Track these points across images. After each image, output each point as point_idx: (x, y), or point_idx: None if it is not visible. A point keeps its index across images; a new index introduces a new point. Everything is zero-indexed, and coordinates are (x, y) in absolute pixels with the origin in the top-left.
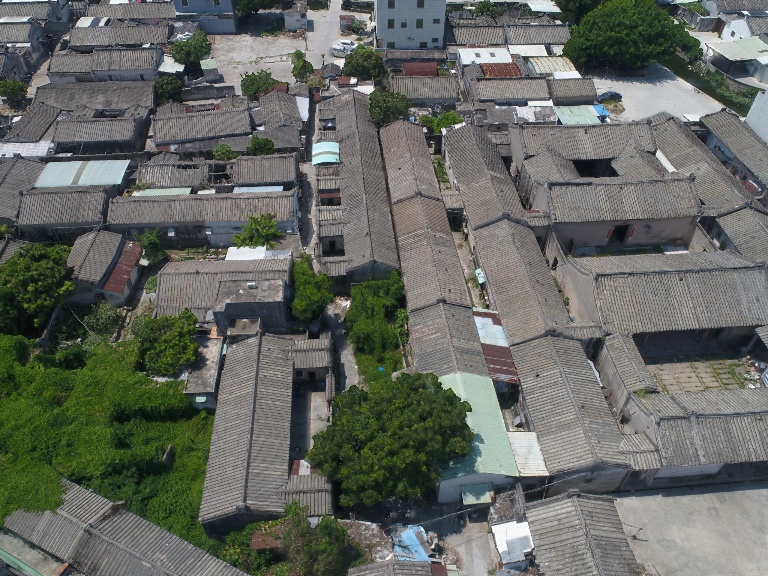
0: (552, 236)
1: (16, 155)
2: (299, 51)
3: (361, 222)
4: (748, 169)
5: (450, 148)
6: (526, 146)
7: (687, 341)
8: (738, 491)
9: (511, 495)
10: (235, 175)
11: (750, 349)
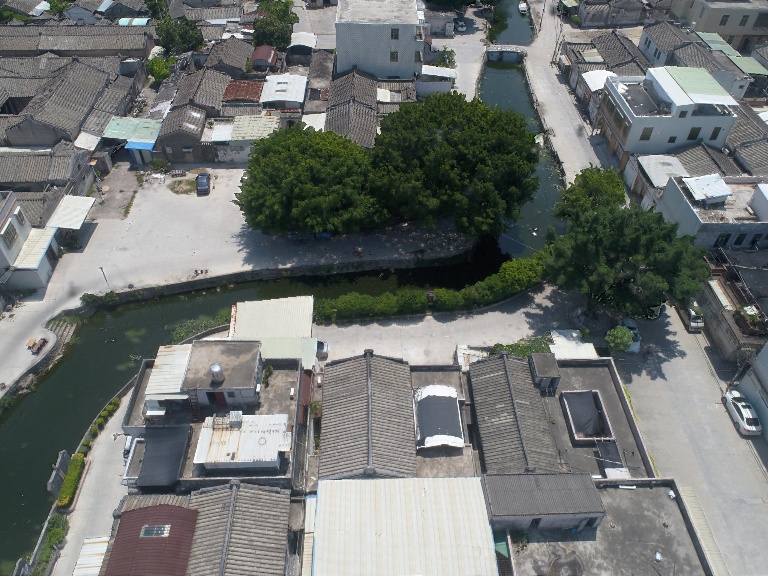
0: None
1: None
2: (287, 1)
3: None
4: None
5: None
6: None
7: None
8: None
9: None
10: None
11: None
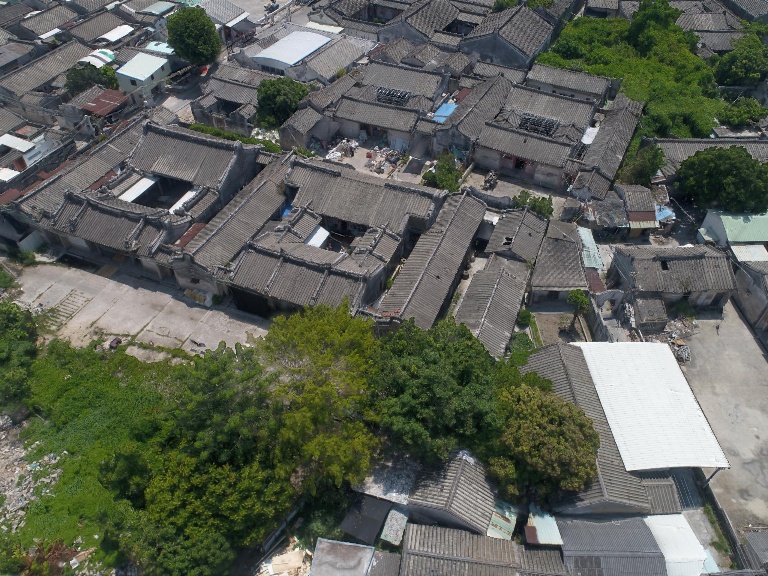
0: None
1: None
2: None
3: None
4: None
5: None
6: None
7: None
8: None
9: None
10: None
11: None
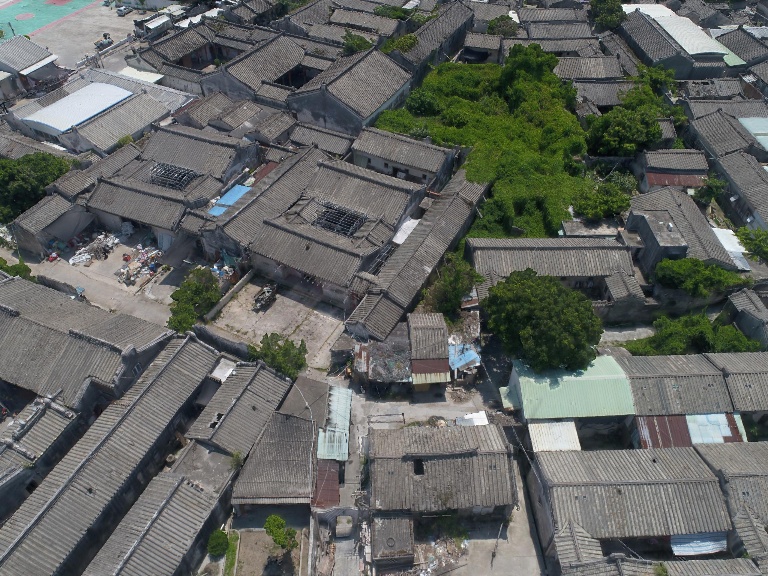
0: None
1: (766, 99)
2: None
3: None
4: None
5: None
6: None
7: None
8: None
9: None
10: None
11: None
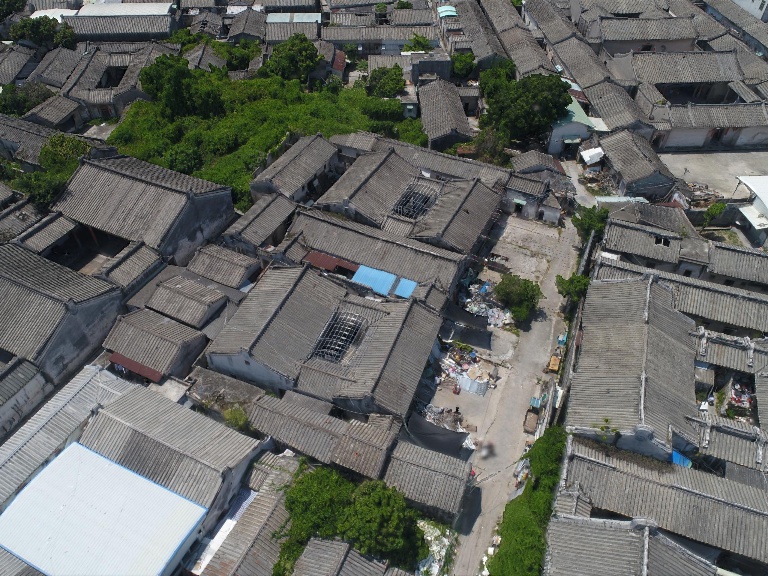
0: (603, 49)
1: (249, 7)
2: None
3: (482, 39)
4: (731, 21)
5: (530, 9)
6: (583, 4)
7: (687, 101)
8: (714, 153)
9: (590, 141)
10: (393, 19)
11: (725, 101)
